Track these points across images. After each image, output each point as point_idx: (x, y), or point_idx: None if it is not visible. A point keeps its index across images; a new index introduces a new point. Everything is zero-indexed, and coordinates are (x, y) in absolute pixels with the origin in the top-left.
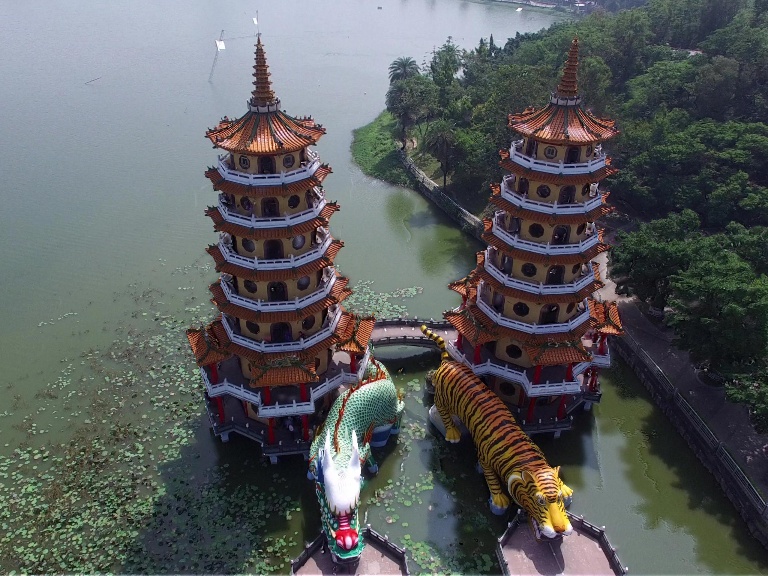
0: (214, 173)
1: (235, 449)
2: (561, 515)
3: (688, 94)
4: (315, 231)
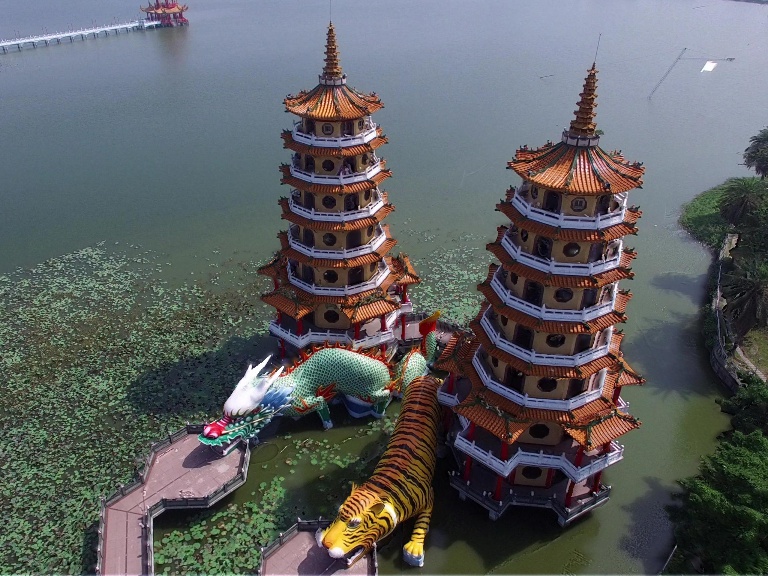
0: None
1: None
2: (339, 535)
3: None
4: (357, 201)
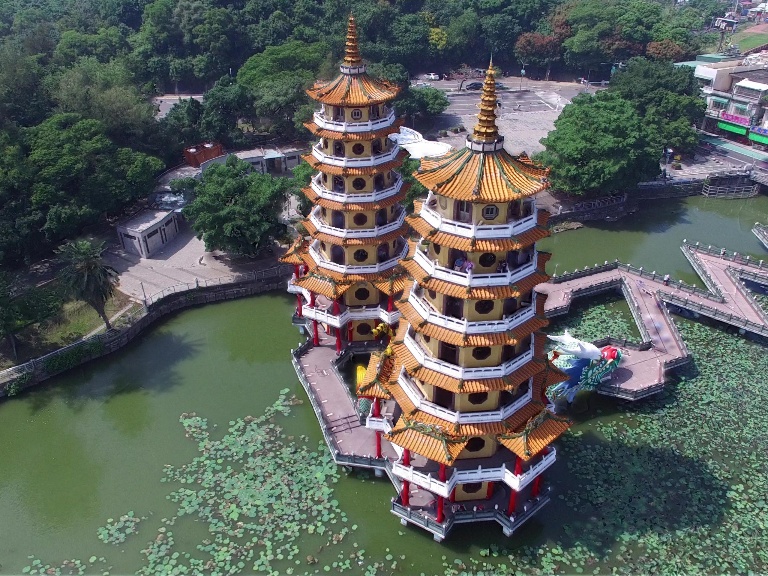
0: (518, 240)
1: None
2: None
3: None
4: None
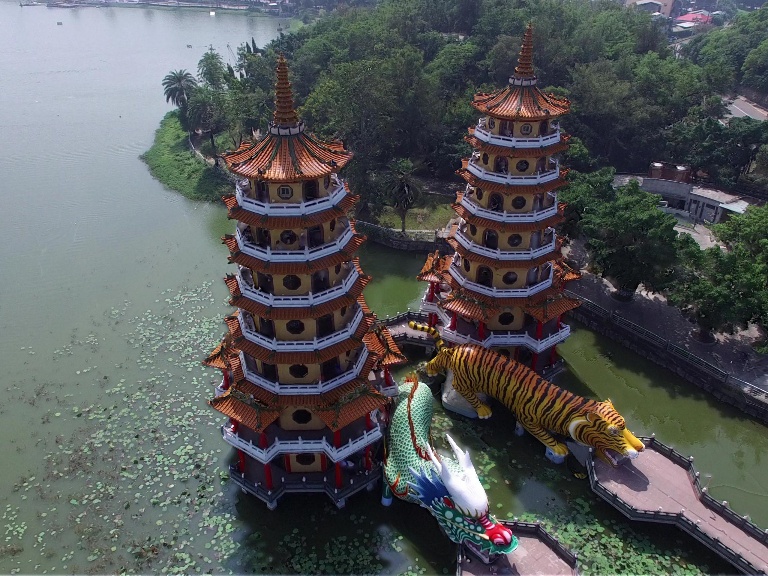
0: (239, 212)
1: (289, 512)
2: (633, 437)
3: (487, 70)
4: None
